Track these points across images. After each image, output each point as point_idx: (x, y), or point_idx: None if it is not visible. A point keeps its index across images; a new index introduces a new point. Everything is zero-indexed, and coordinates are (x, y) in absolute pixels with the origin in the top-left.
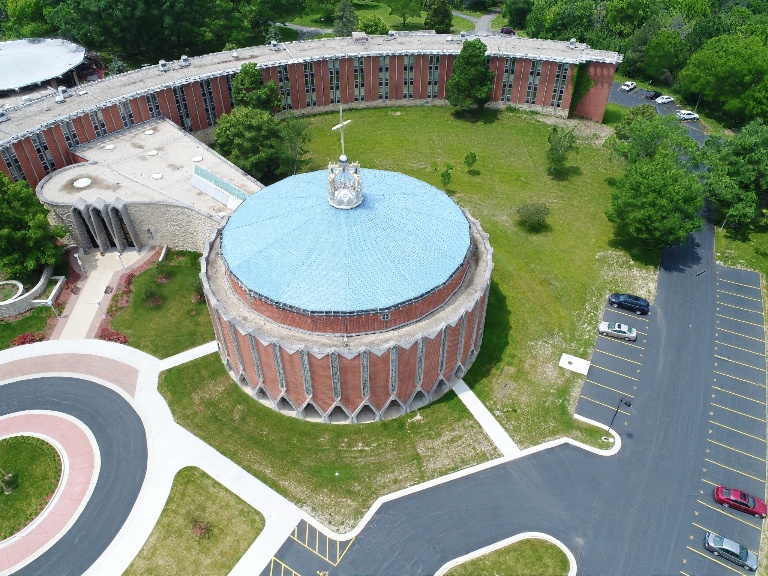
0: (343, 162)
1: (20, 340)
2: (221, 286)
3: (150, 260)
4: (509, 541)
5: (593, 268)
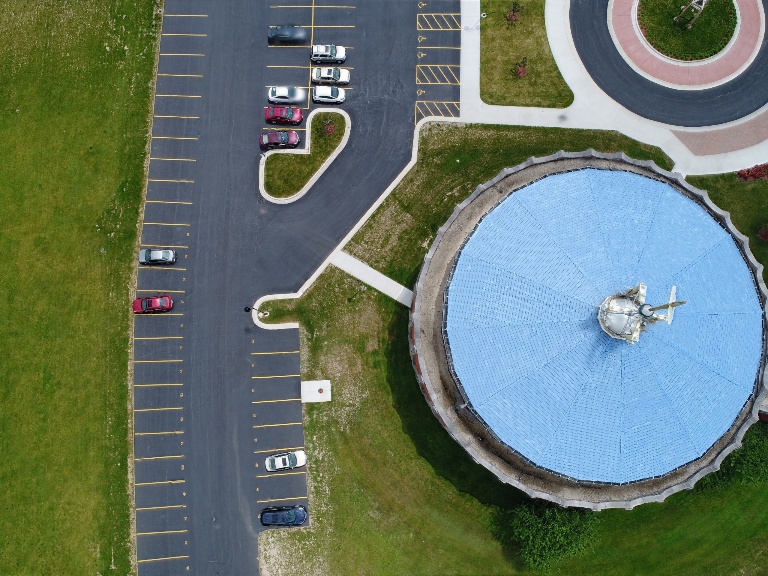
0: (643, 305)
1: None
2: None
3: None
4: (311, 183)
5: (340, 570)
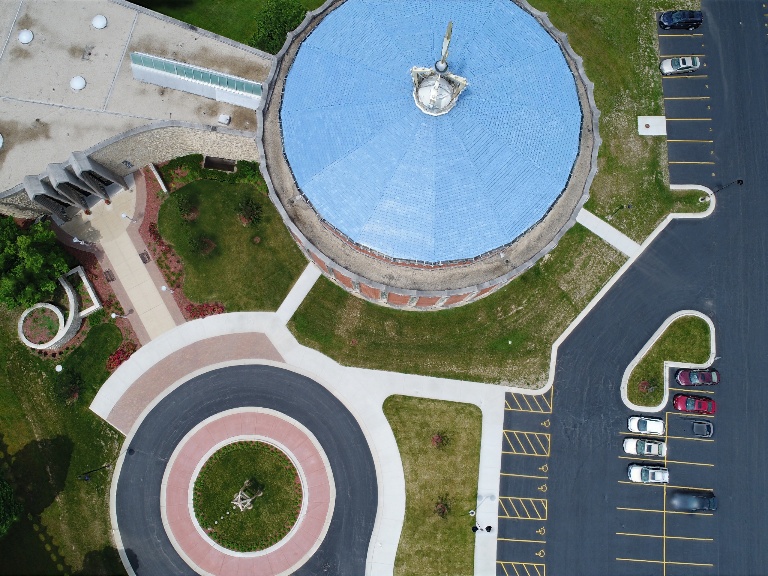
0: (444, 72)
1: (116, 362)
2: (334, 247)
3: (151, 194)
4: (661, 330)
5: None
